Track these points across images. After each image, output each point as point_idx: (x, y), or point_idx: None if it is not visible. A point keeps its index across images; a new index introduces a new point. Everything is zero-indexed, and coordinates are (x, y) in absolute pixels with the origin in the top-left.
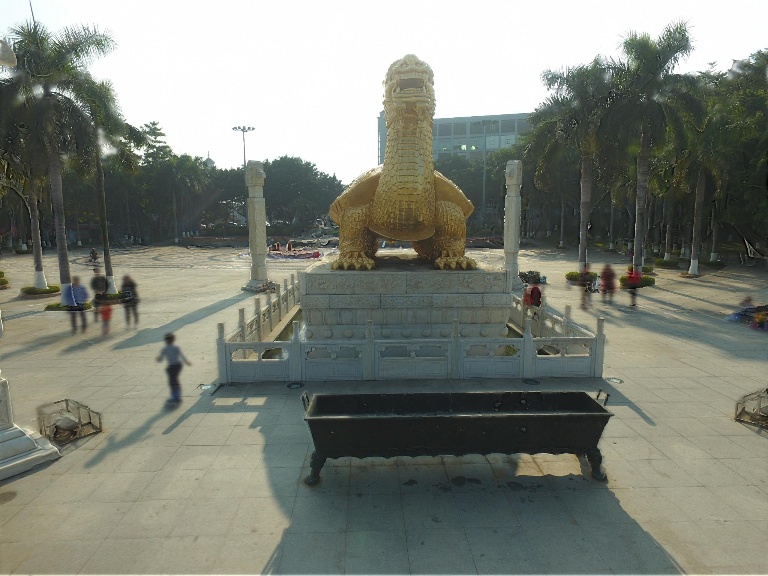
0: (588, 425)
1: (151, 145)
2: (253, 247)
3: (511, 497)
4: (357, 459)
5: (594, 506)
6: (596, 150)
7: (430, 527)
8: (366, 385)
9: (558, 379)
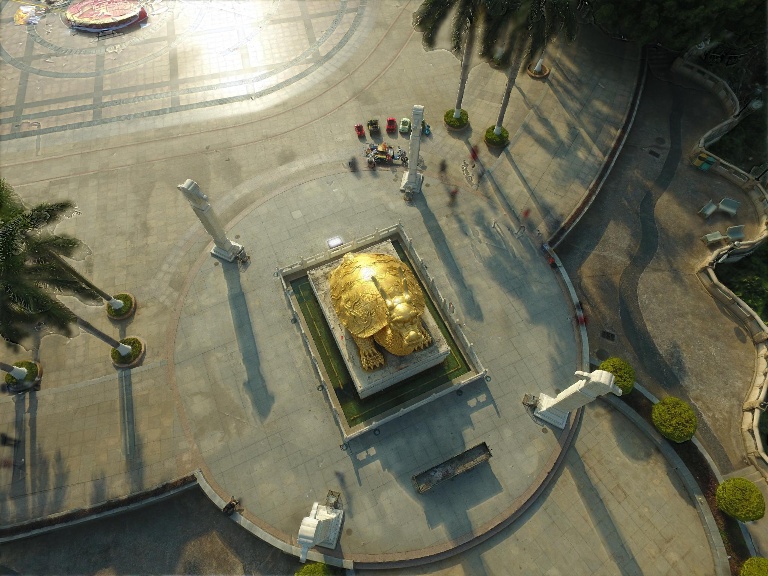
0: None
1: (79, 211)
2: (213, 234)
3: (468, 477)
4: None
5: (486, 473)
6: (483, 29)
7: (454, 497)
8: (402, 421)
9: (468, 386)
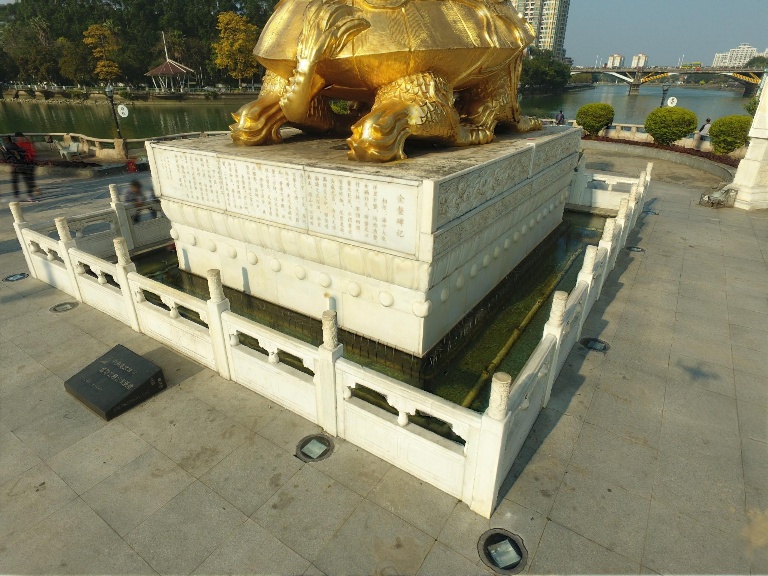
0: None
1: None
2: None
3: None
4: None
5: None
6: None
7: None
8: None
9: None
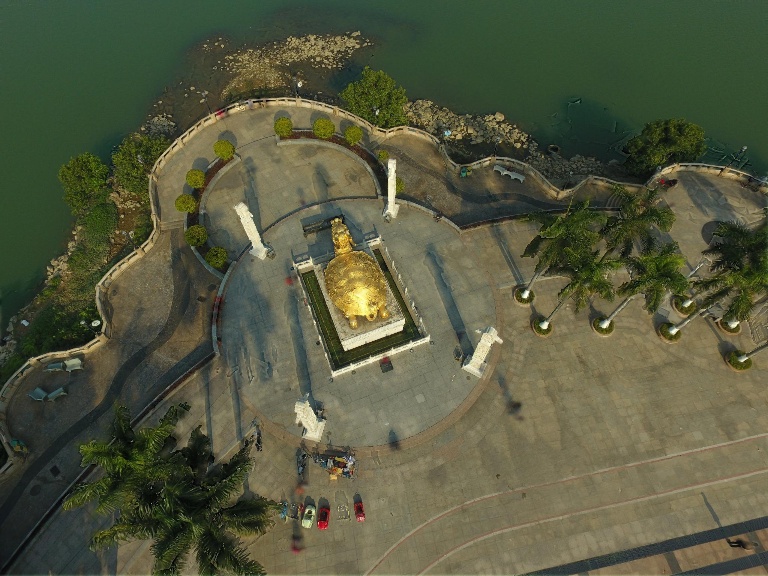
0: None
1: None
2: None
3: None
4: None
5: None
6: None
7: None
8: None
9: None
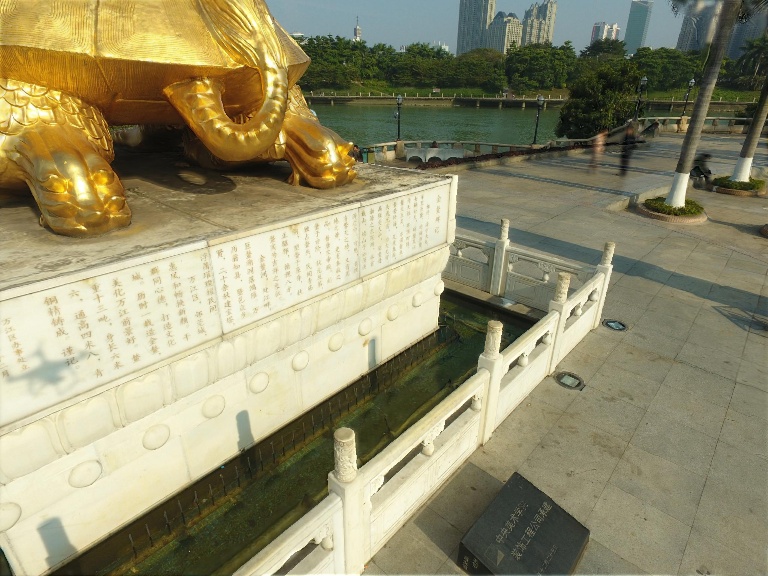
0: None
1: None
2: None
3: None
4: None
5: None
6: None
7: None
8: None
9: None
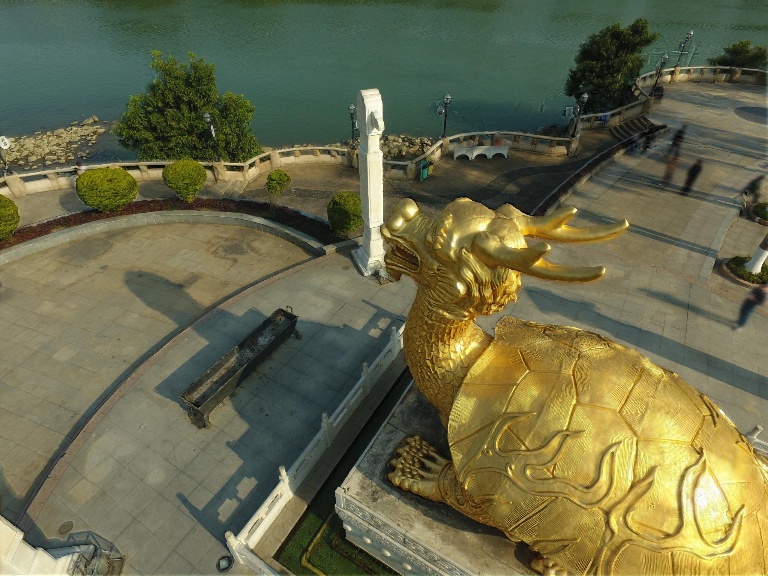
0: (190, 392)
1: None
2: None
3: None
4: (285, 347)
5: None
6: None
7: None
8: None
9: None
